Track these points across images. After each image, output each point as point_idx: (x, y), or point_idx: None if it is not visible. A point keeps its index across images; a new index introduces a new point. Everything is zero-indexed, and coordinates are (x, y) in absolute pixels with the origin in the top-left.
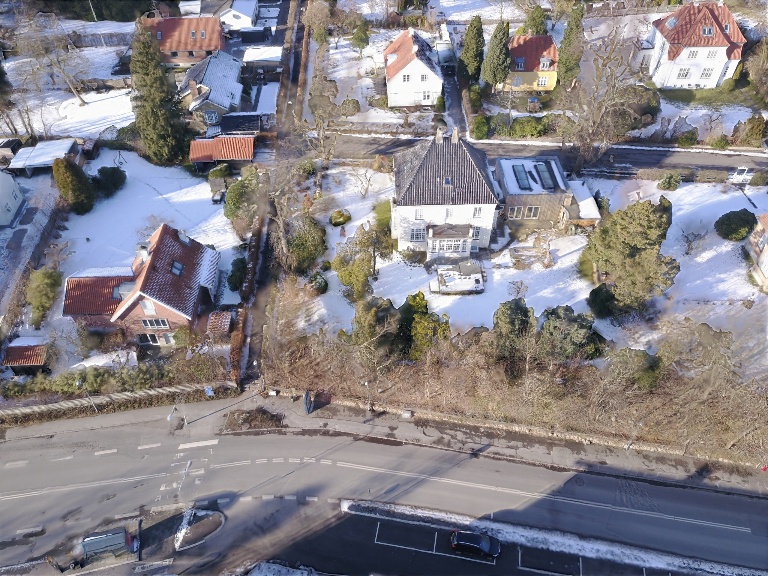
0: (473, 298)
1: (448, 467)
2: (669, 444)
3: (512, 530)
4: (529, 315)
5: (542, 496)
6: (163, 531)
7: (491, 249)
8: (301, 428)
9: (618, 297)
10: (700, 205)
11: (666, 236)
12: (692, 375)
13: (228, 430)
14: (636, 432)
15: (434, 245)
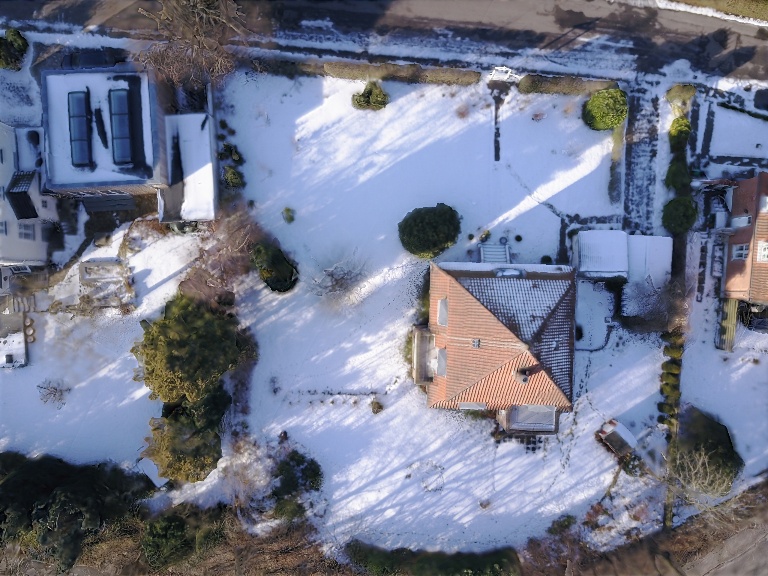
0: (13, 374)
1: None
2: None
3: None
4: None
5: None
6: None
7: (51, 264)
8: None
9: None
10: (406, 155)
11: (297, 276)
12: (257, 531)
13: None
14: (195, 571)
15: None
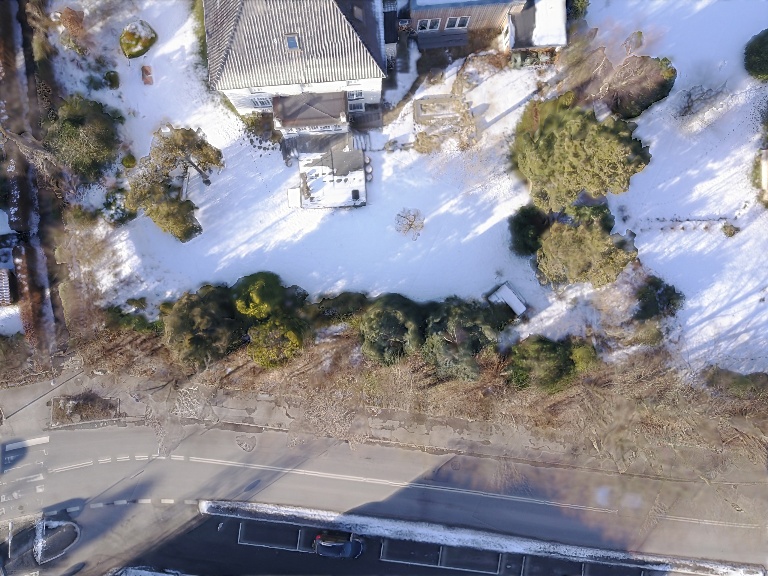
0: (350, 214)
1: (313, 457)
2: (562, 426)
3: (377, 525)
4: (405, 339)
5: (412, 485)
6: (19, 546)
7: (385, 103)
8: (142, 417)
9: (542, 270)
10: None
11: None
12: (612, 359)
13: (57, 424)
14: (529, 412)
15: None
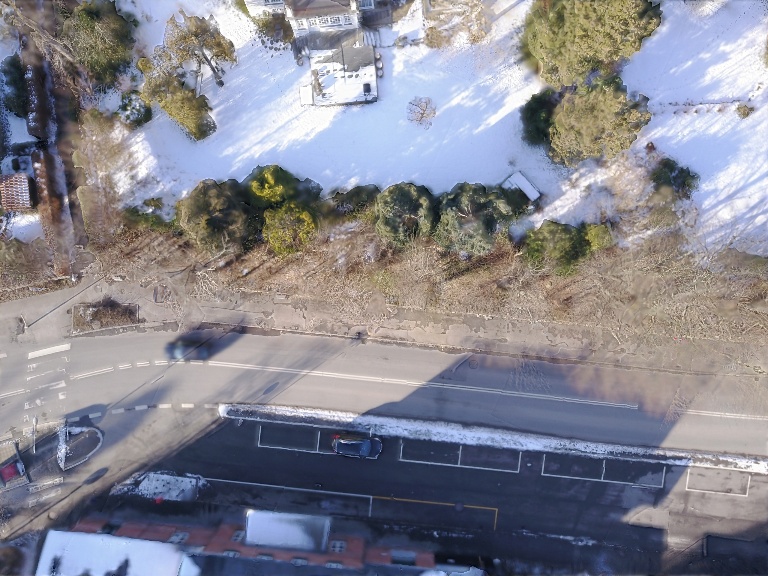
0: (362, 111)
1: (331, 358)
2: (579, 320)
3: (396, 425)
4: (420, 214)
5: (430, 385)
6: (43, 453)
7: None
8: (161, 322)
9: (555, 147)
10: None
11: None
12: (628, 244)
13: (77, 331)
14: (546, 306)
15: (299, 22)
